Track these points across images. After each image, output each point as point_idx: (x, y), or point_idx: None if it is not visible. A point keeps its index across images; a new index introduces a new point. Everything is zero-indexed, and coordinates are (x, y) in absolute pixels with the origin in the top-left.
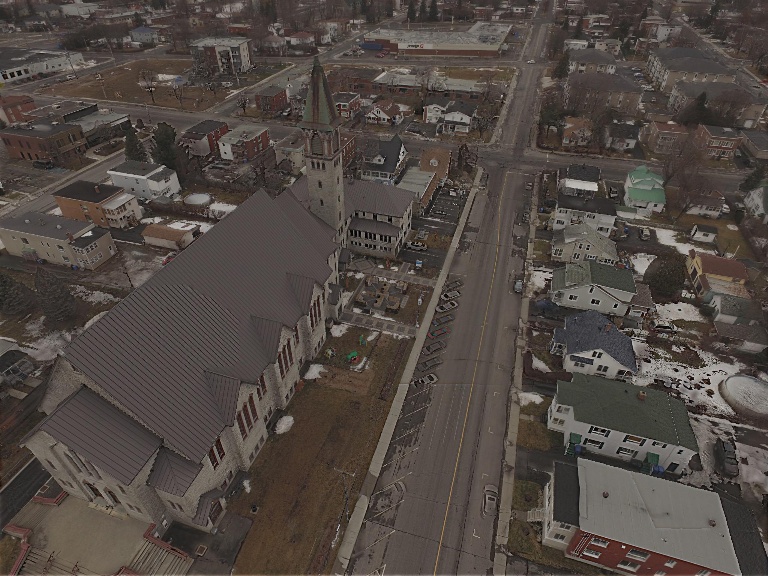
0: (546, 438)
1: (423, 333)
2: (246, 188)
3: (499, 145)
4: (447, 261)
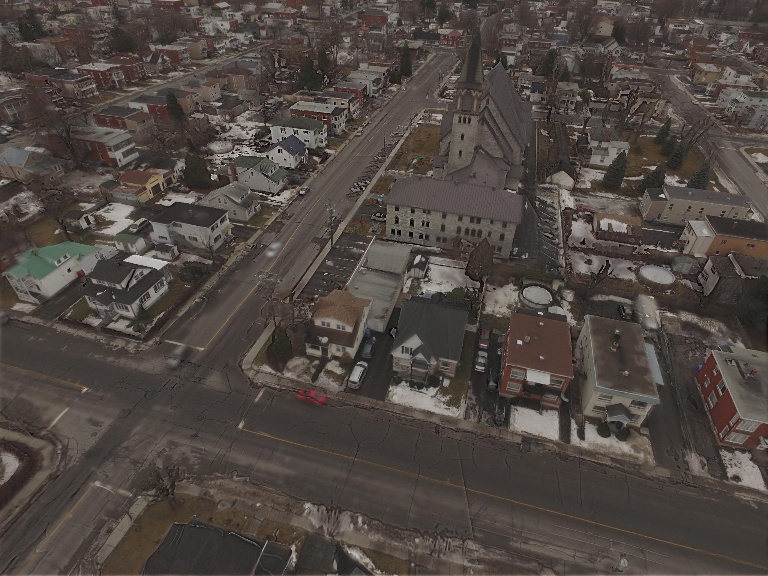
0: (330, 142)
1: (380, 172)
2: (618, 293)
3: (136, 480)
4: (355, 211)
